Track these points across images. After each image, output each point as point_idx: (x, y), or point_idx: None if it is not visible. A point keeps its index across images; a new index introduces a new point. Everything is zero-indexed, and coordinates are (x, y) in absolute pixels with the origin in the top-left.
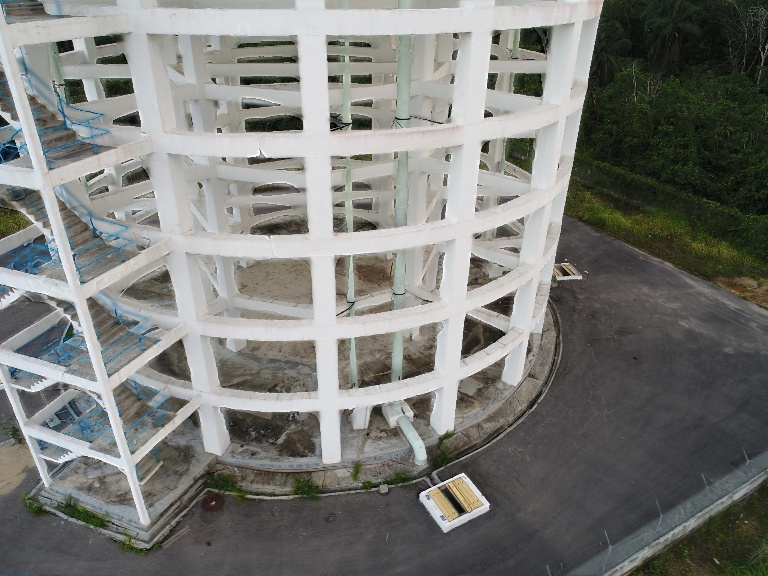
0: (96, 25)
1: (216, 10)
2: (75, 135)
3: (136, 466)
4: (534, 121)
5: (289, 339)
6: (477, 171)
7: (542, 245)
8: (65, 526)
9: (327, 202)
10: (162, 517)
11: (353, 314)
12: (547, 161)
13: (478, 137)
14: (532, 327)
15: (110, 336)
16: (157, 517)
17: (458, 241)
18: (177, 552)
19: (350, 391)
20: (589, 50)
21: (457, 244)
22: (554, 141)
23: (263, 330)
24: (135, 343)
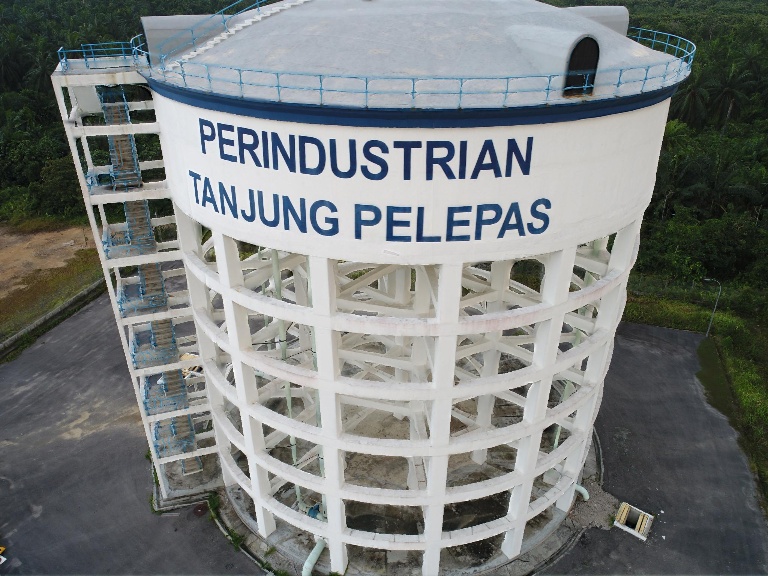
0: (160, 257)
1: (198, 268)
2: (165, 295)
3: (188, 463)
4: (392, 394)
5: (237, 446)
6: (334, 410)
7: (440, 485)
8: (148, 472)
9: (242, 384)
10: (175, 499)
11: (294, 452)
12: (432, 424)
13: (331, 389)
14: (446, 545)
15: (174, 392)
16: (173, 498)
17: (325, 448)
18: (163, 523)
19: (271, 499)
20: (544, 345)
21: (325, 449)
22: (434, 413)
23: (228, 433)
24: (171, 404)
